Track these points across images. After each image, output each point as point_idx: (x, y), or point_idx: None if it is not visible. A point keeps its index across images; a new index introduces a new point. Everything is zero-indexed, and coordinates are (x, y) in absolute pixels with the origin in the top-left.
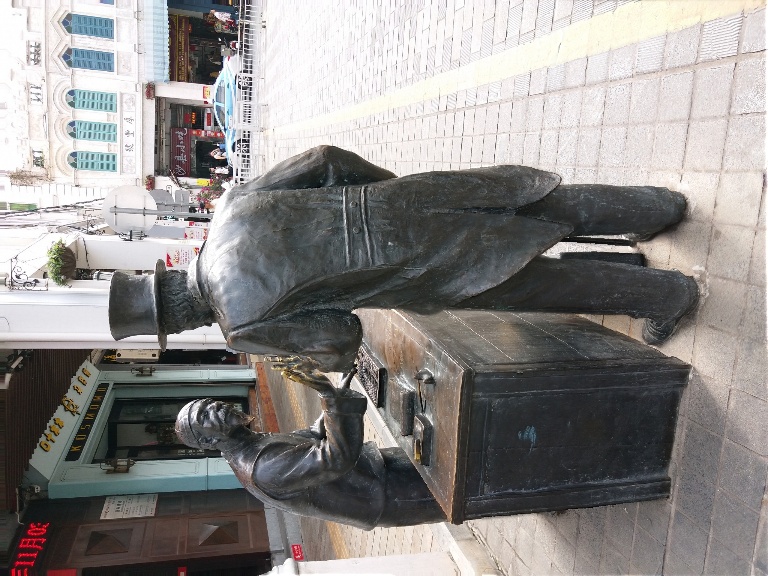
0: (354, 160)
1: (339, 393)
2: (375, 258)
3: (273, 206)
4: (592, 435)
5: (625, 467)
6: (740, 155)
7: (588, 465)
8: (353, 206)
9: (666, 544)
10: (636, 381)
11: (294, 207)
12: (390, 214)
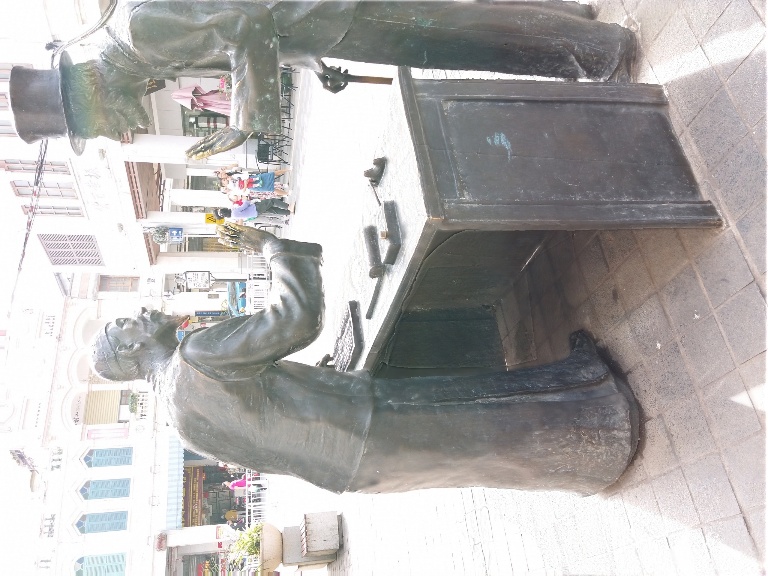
0: None
1: None
2: None
3: None
4: (581, 150)
5: (643, 187)
6: None
7: (592, 182)
8: None
9: (753, 276)
10: (604, 93)
11: None
12: None
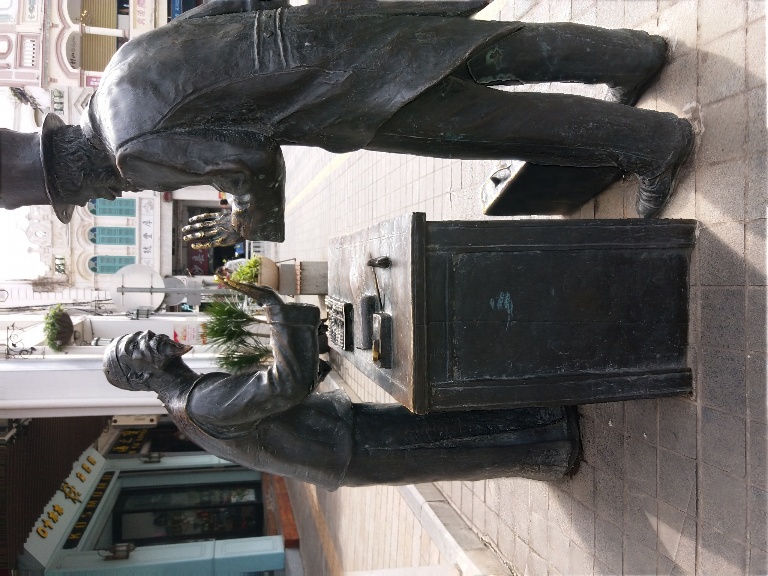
0: None
1: None
2: (289, 59)
3: (176, 25)
4: (584, 308)
5: (631, 353)
6: None
7: (584, 348)
8: (266, 17)
9: (697, 456)
10: (630, 236)
11: (200, 24)
12: (308, 20)
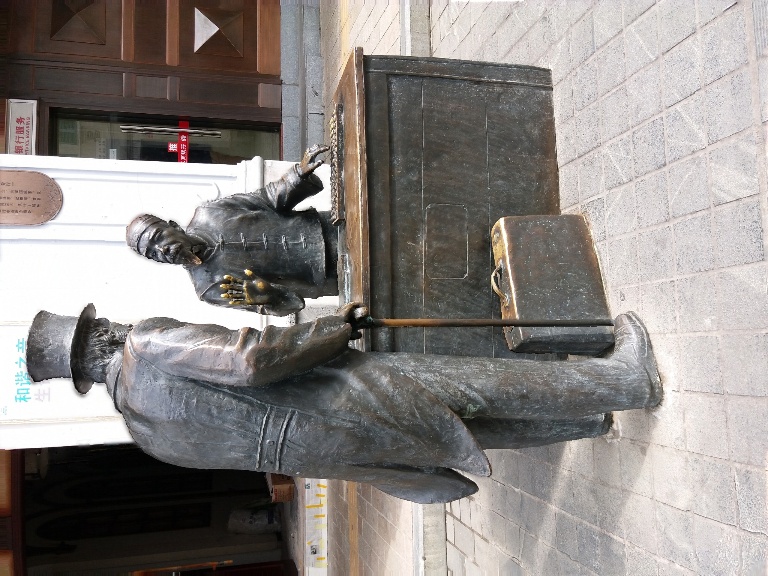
0: (287, 372)
1: (280, 295)
2: None
3: (186, 421)
4: None
5: None
6: (701, 480)
7: None
8: (269, 445)
9: None
10: None
11: (208, 427)
12: (305, 458)
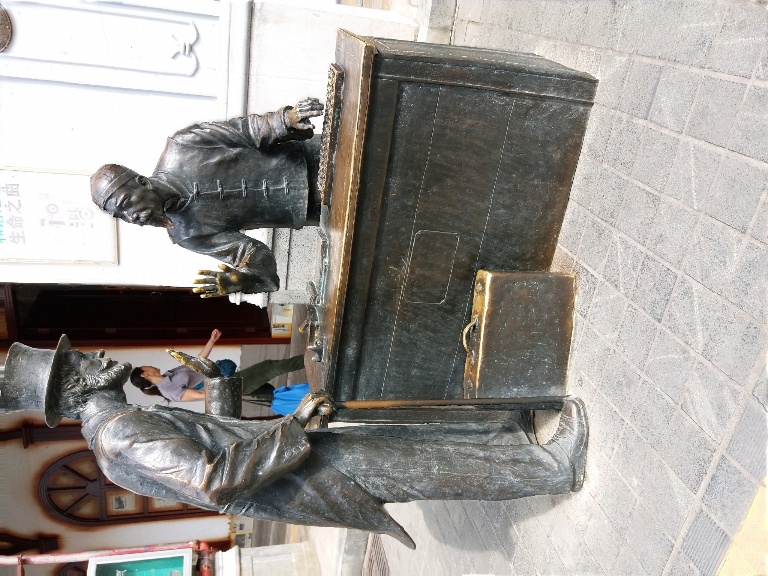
0: None
1: (255, 278)
2: None
3: None
4: None
5: None
6: (584, 566)
7: None
8: None
9: None
10: None
11: None
12: None
